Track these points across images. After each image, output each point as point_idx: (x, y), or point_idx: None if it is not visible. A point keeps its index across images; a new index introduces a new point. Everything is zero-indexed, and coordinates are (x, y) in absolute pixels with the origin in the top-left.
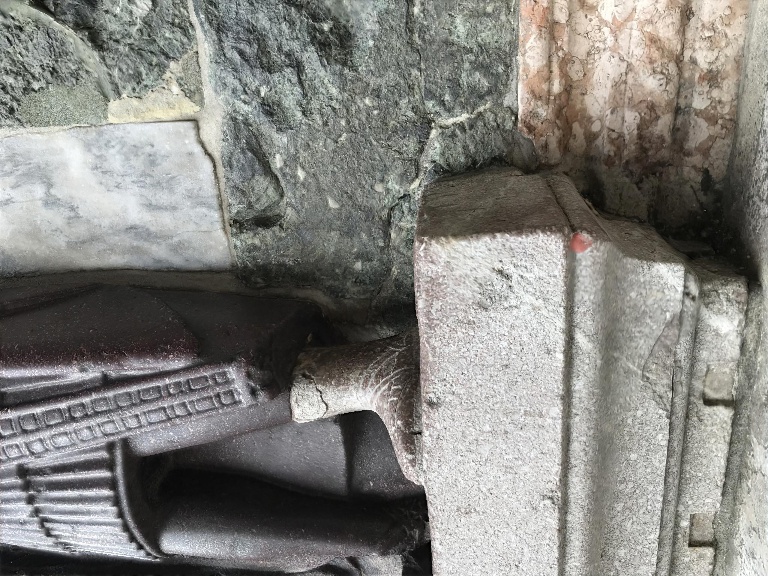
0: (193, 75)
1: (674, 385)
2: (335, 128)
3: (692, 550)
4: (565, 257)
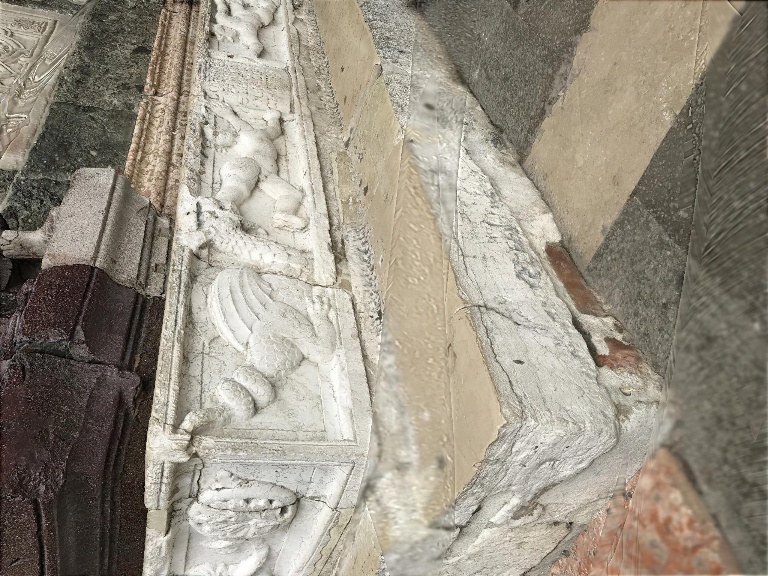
0: (2, 198)
1: (147, 221)
2: (48, 213)
3: (156, 273)
4: (115, 172)
